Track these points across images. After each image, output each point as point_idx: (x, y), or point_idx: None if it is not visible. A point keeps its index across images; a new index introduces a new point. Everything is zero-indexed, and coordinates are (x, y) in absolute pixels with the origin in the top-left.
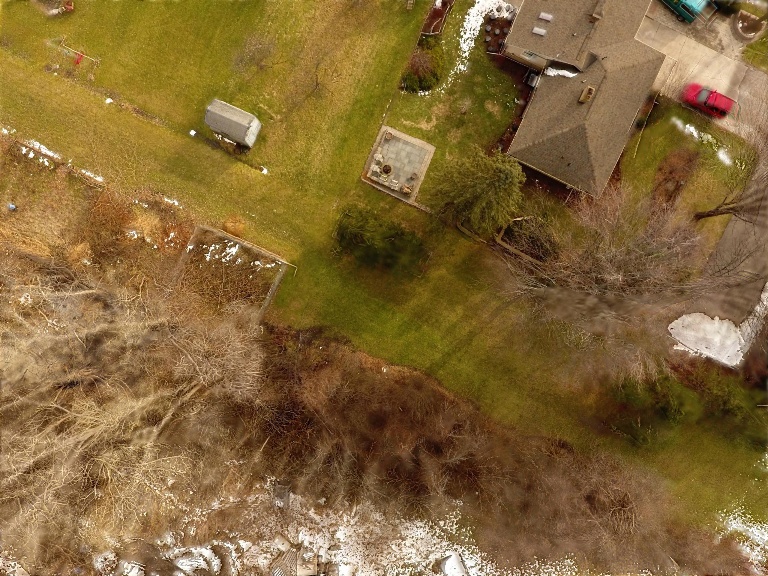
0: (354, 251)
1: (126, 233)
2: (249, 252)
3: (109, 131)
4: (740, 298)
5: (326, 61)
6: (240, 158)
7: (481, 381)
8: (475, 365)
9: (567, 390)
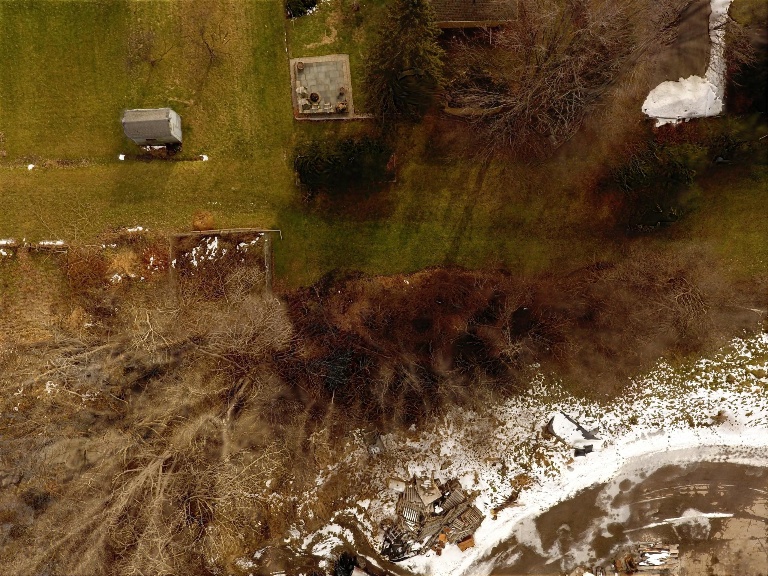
0: (323, 188)
1: (109, 279)
2: (229, 238)
3: (45, 194)
4: (693, 50)
5: (208, 28)
6: (177, 158)
7: (499, 247)
8: (486, 235)
9: (580, 215)
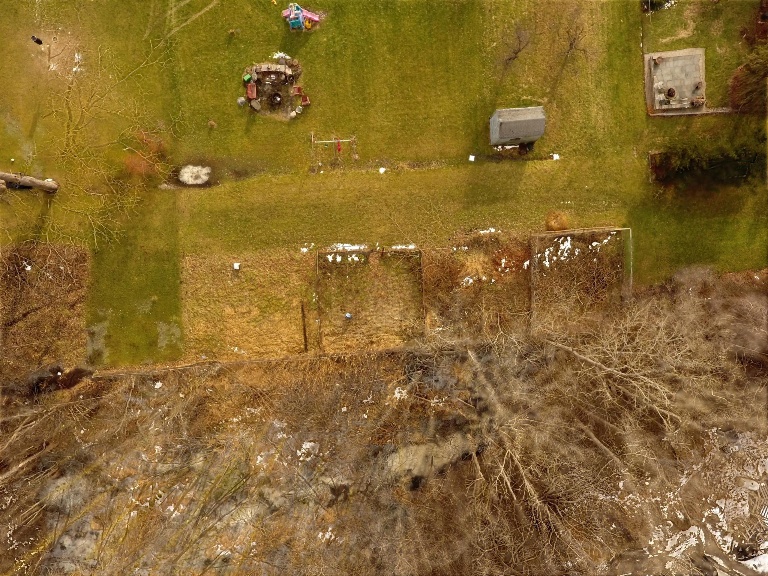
0: (678, 184)
1: (460, 283)
2: (583, 238)
3: (399, 197)
4: None
5: (564, 24)
6: (527, 157)
7: None
8: None
9: None
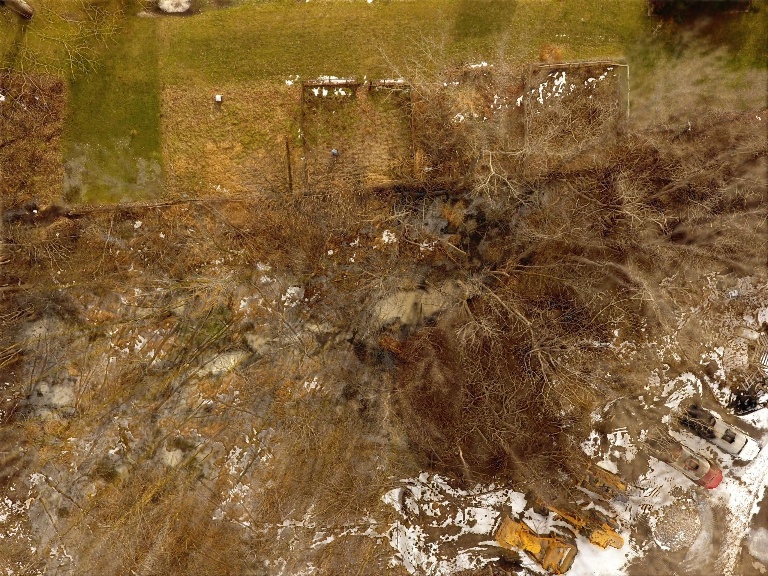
0: (678, 17)
1: (451, 120)
2: (579, 73)
3: (388, 28)
4: None
5: None
6: None
7: None
8: None
9: None
